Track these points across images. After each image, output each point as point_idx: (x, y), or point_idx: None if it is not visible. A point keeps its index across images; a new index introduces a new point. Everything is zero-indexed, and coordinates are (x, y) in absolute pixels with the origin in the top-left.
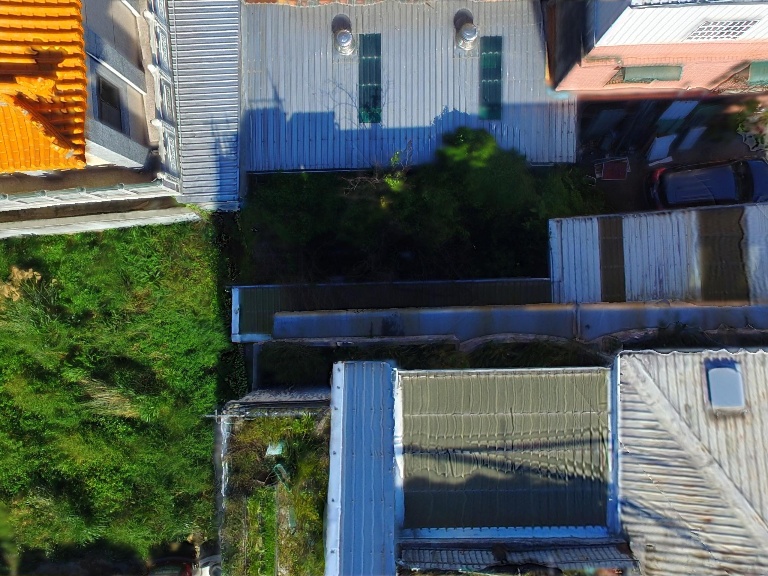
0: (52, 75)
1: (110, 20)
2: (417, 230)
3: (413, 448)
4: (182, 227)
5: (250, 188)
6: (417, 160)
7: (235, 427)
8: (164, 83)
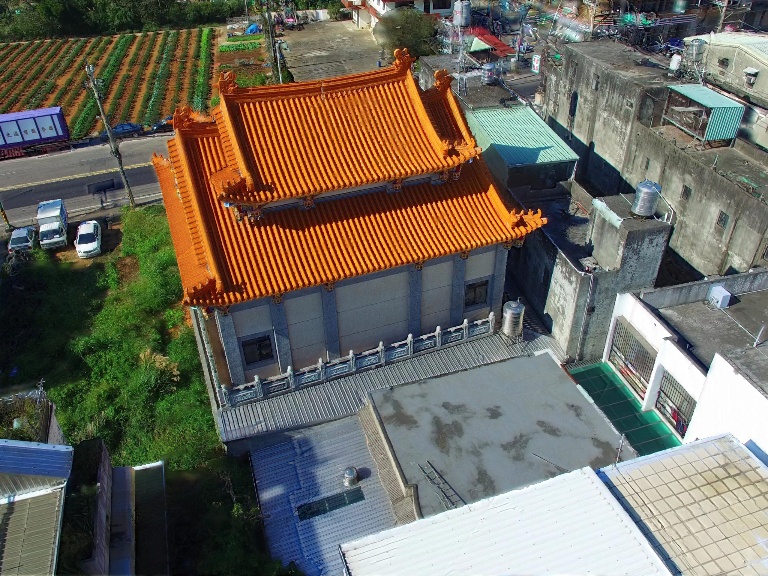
0: (231, 291)
1: (309, 343)
2: (205, 549)
3: (3, 510)
4: (216, 440)
5: (240, 457)
6: (276, 556)
7: (34, 395)
8: (288, 382)
